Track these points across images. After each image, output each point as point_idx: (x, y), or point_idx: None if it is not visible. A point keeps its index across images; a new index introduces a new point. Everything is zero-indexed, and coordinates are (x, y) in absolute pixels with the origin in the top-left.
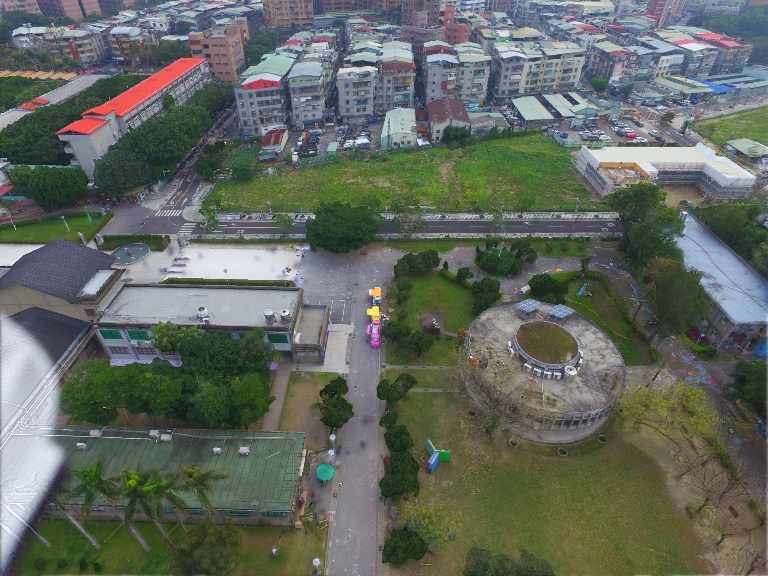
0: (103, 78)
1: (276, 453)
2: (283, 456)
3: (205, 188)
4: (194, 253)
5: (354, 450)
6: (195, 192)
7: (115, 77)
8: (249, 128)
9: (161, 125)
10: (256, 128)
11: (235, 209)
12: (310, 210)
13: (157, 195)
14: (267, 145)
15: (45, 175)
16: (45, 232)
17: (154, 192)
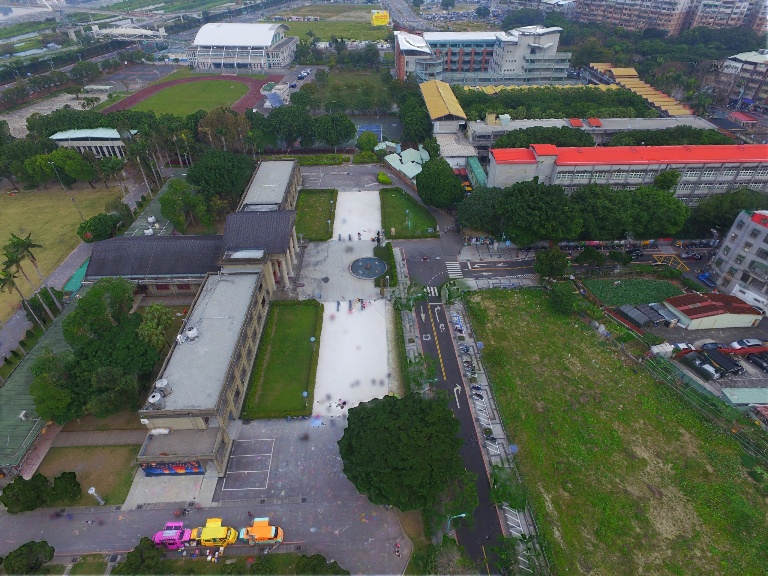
0: (692, 126)
1: (8, 442)
2: (1, 449)
3: (523, 280)
4: (375, 310)
5: (1, 529)
6: (510, 275)
7: (702, 130)
8: (719, 272)
9: (589, 195)
10: (727, 279)
11: (476, 319)
12: (428, 389)
13: (489, 251)
14: (673, 304)
15: (428, 174)
16: (401, 213)
17: (493, 247)
